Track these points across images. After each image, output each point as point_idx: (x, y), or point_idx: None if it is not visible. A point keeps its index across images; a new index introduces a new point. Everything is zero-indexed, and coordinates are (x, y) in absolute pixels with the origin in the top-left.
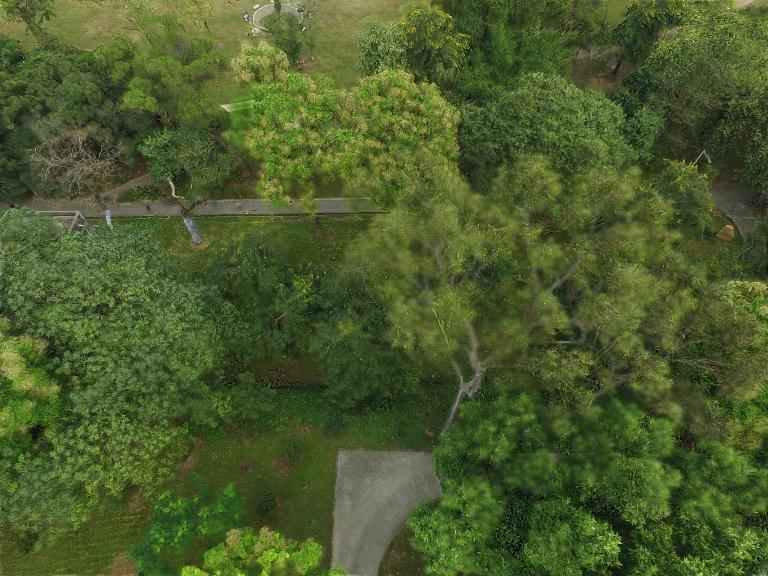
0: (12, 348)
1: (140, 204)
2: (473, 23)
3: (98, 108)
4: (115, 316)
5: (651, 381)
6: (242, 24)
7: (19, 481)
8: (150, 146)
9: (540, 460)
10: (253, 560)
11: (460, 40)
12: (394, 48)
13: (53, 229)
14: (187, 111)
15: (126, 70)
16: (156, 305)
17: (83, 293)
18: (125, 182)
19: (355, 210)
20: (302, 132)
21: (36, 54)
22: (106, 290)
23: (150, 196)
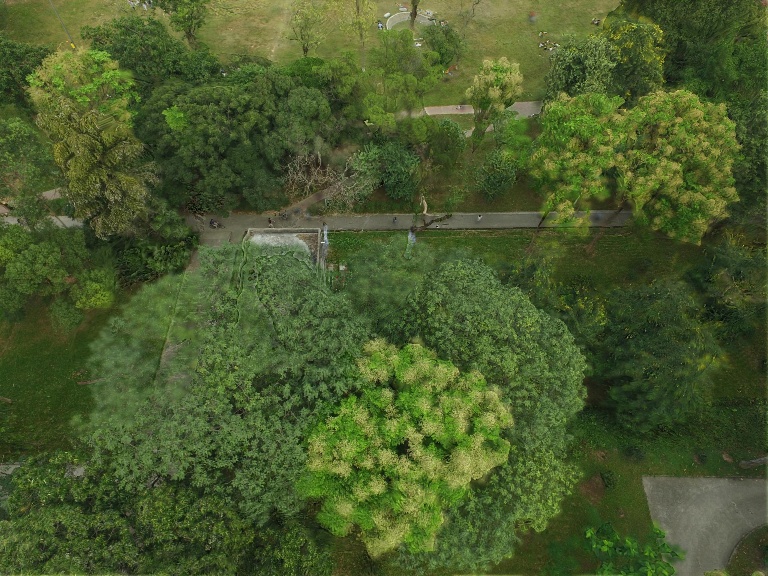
0: (480, 385)
1: (330, 217)
2: (668, 36)
3: (326, 123)
4: (519, 348)
5: None
6: (377, 32)
7: (474, 520)
8: (361, 161)
9: None
10: None
11: (660, 54)
12: (606, 63)
13: (297, 246)
14: (415, 127)
15: (352, 85)
16: (547, 336)
17: (499, 325)
18: (310, 195)
19: (546, 224)
20: (612, 154)
21: (235, 66)
22: (510, 321)
23: (339, 209)
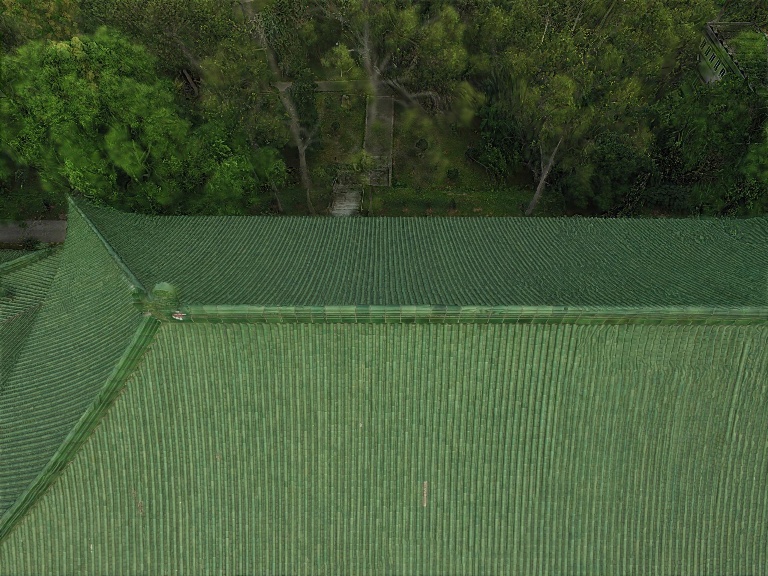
0: None
1: None
2: None
3: None
4: None
5: (203, 188)
6: None
7: None
8: None
9: None
10: None
11: None
12: None
13: None
14: None
15: None
16: None
17: None
18: None
19: None
20: None
21: None
22: None
23: None
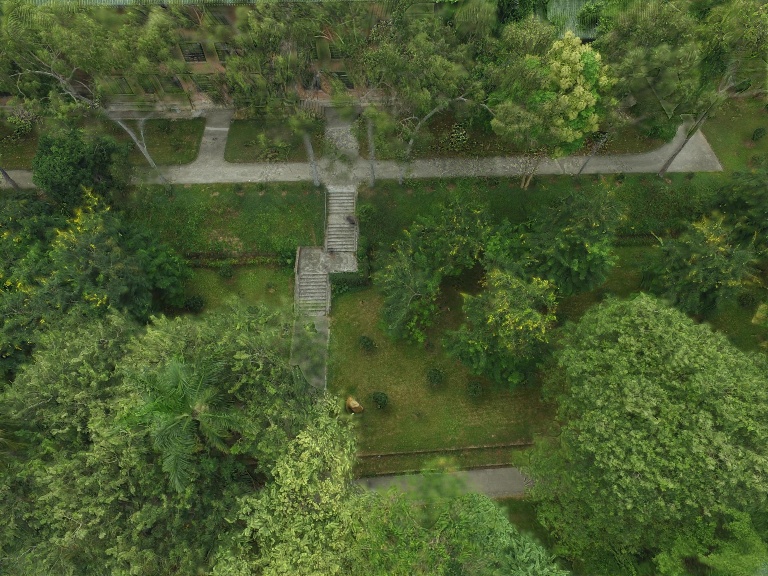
0: None
1: None
2: None
3: None
4: None
5: None
6: None
7: None
8: None
9: (588, 171)
10: (745, 125)
11: None
12: None
13: None
14: None
15: None
16: None
17: None
18: None
19: None
20: None
21: None
22: None
23: None
